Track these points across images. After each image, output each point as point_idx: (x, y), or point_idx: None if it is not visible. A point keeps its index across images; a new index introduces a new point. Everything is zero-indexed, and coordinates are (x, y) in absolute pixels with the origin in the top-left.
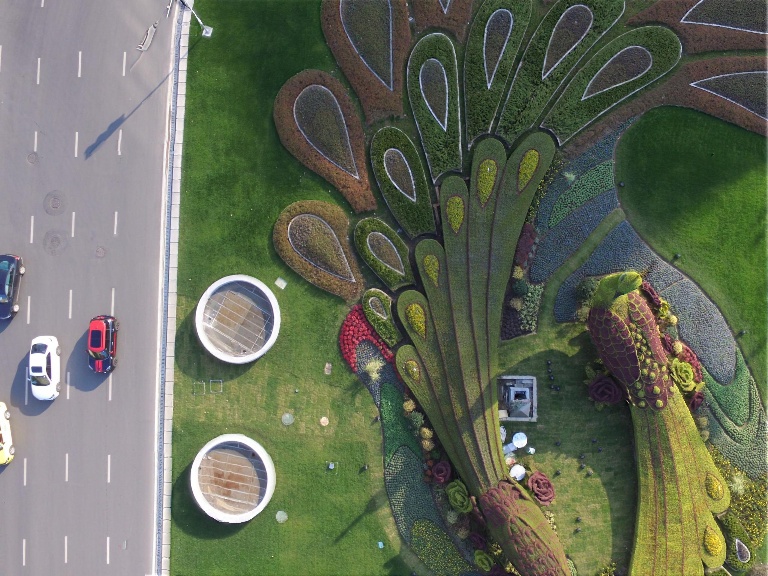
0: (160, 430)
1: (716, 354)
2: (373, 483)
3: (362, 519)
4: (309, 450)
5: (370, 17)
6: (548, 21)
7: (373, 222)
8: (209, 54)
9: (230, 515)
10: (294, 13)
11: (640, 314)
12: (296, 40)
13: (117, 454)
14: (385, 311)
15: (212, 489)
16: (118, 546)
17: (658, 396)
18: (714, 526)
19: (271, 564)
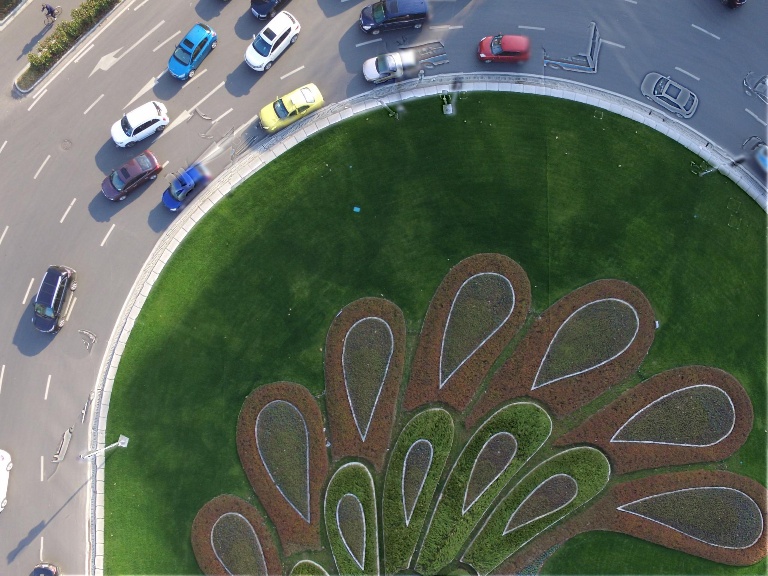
0: None
1: None
2: None
3: None
4: None
5: (286, 446)
6: (470, 452)
7: None
8: (126, 467)
9: None
10: (210, 432)
11: None
12: (212, 462)
13: None
14: None
15: None
16: None
17: None
18: None
19: None
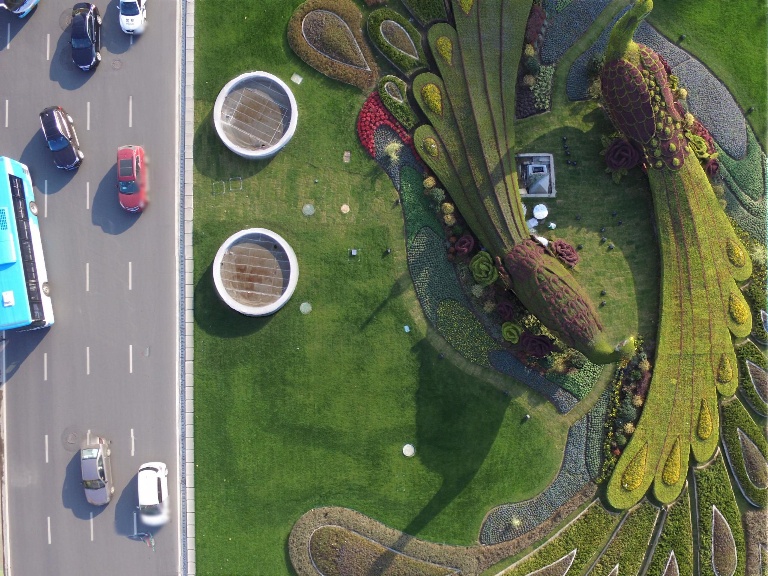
0: (180, 234)
1: (727, 129)
2: (396, 267)
3: (387, 304)
4: (331, 239)
5: None
6: None
7: (385, 11)
8: None
9: (254, 307)
10: None
11: (652, 61)
12: None
13: (138, 259)
14: (401, 95)
15: (235, 286)
16: (140, 353)
17: (674, 154)
18: (738, 293)
19: (297, 357)
